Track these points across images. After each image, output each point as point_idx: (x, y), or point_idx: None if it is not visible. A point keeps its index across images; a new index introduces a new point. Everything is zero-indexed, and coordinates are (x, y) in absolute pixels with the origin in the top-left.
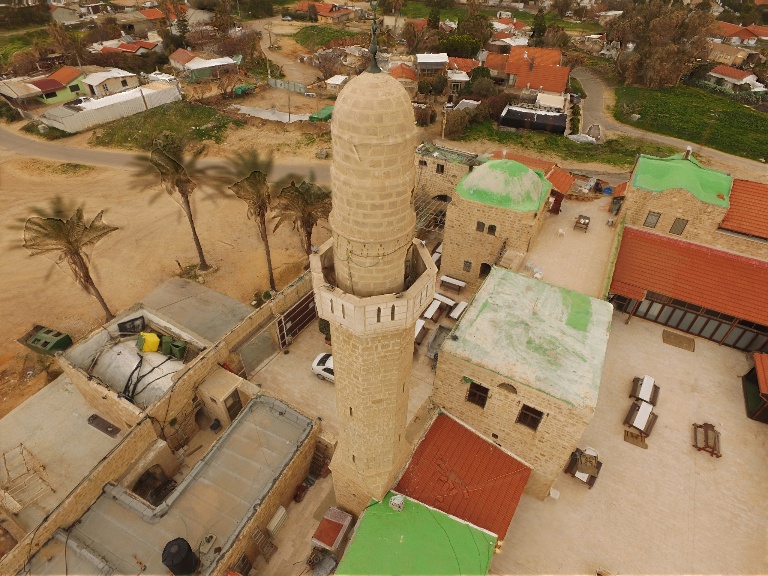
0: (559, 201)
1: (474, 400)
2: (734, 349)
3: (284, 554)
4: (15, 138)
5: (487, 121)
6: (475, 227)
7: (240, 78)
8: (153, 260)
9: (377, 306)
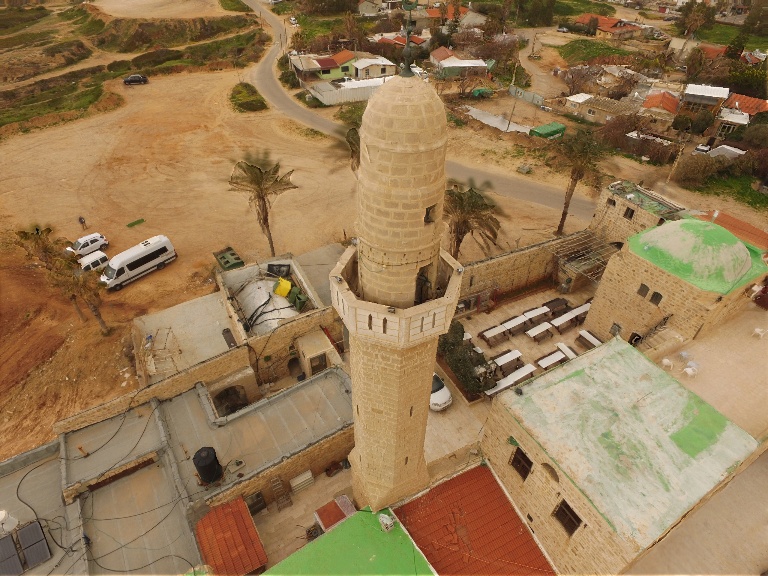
0: None
1: (517, 467)
2: None
3: (295, 512)
4: (288, 101)
5: (746, 176)
6: (637, 289)
7: (485, 81)
8: (331, 224)
9: (368, 313)
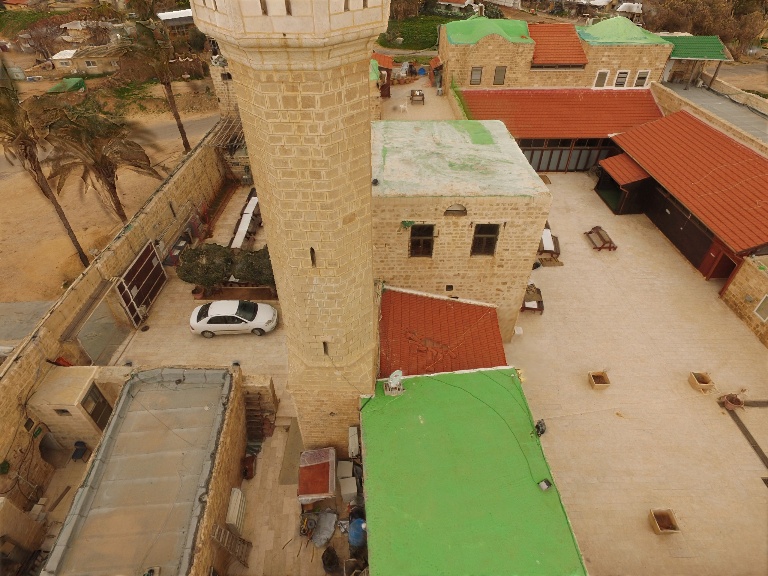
0: (387, 81)
1: (418, 251)
2: (577, 172)
3: (264, 544)
4: None
5: None
6: None
7: None
8: None
9: None
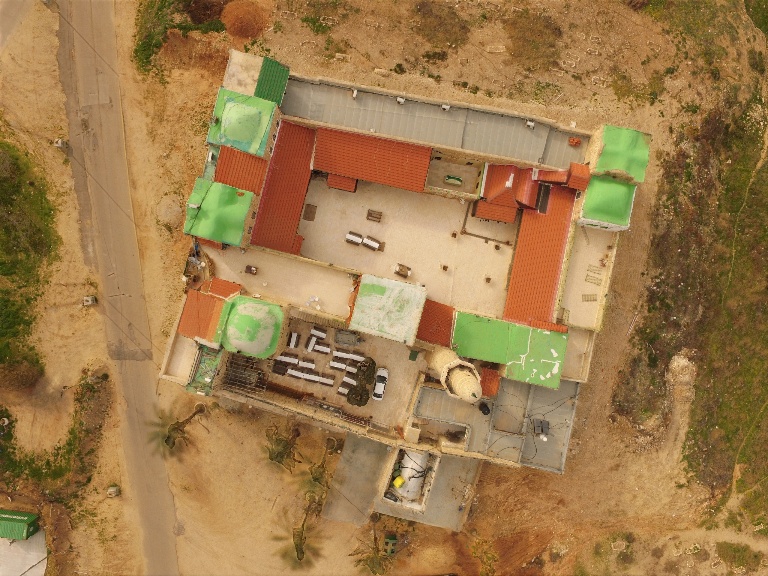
0: None
1: None
2: (309, 185)
3: None
4: None
5: None
6: (281, 339)
7: None
8: None
9: None
